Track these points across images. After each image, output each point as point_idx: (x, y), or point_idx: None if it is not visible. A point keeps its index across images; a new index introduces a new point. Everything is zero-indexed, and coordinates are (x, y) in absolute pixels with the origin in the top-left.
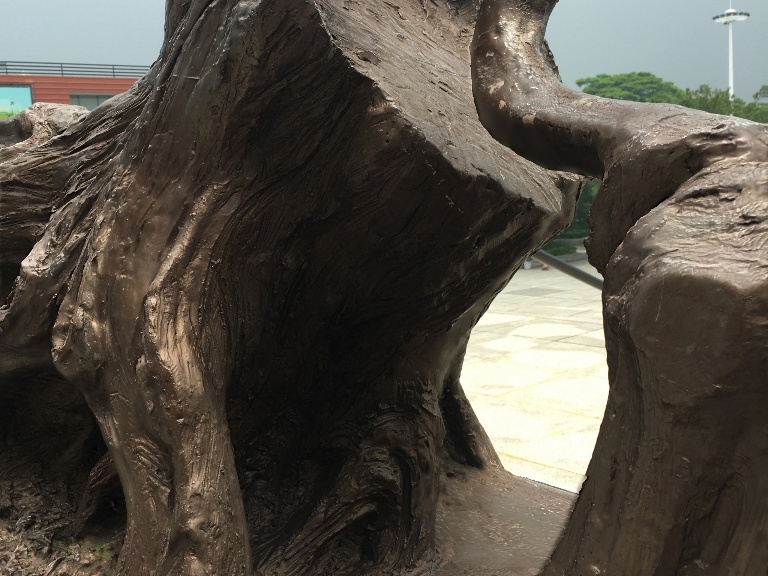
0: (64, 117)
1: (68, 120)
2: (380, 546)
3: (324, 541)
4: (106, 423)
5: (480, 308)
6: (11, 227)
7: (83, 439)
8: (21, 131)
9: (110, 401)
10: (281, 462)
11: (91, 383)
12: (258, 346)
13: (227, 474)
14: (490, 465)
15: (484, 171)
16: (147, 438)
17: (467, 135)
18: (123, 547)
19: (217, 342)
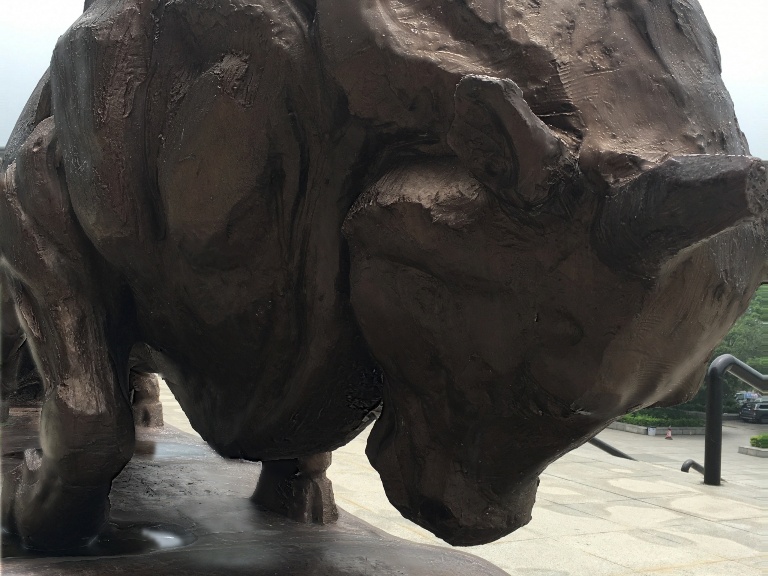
0: None
1: None
2: (38, 395)
3: (20, 389)
4: None
5: None
6: None
7: None
8: None
9: None
10: (20, 368)
11: None
12: None
13: None
14: None
15: None
16: None
17: None
18: None
19: None
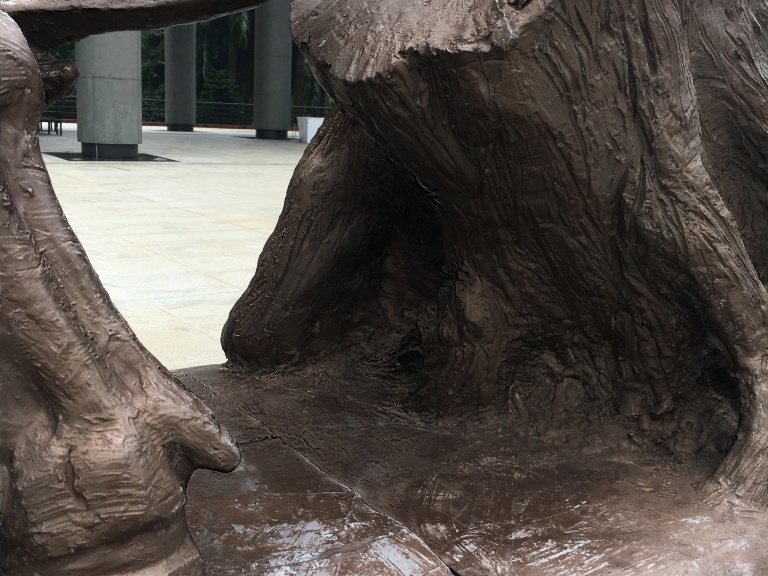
0: None
1: None
2: None
3: None
4: None
5: (486, 199)
6: None
7: None
8: None
9: None
10: None
11: None
12: (396, 183)
13: (288, 239)
14: (715, 478)
15: (310, 38)
16: None
17: (348, 6)
18: None
19: (339, 163)
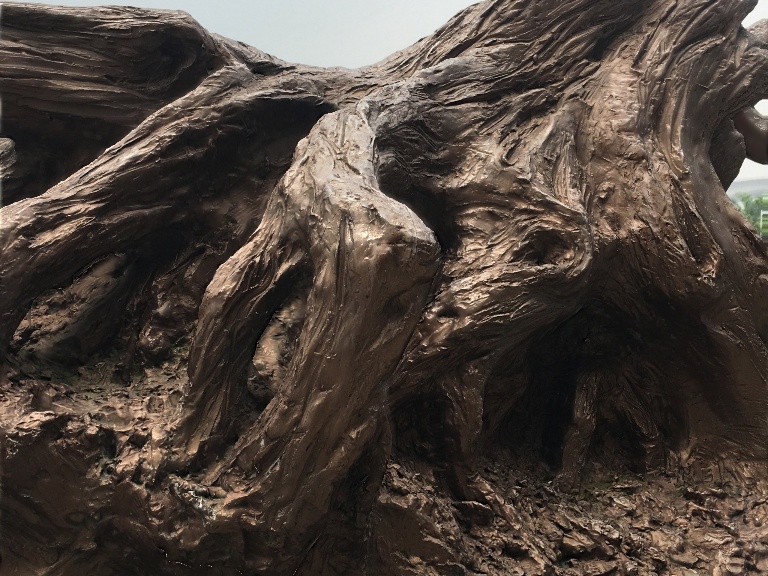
0: (235, 44)
1: (248, 50)
2: None
3: None
4: (727, 333)
5: None
6: (419, 174)
7: (511, 404)
8: (184, 43)
9: (733, 314)
10: None
11: (714, 304)
12: None
13: None
14: None
15: None
16: (758, 335)
17: None
18: None
19: None
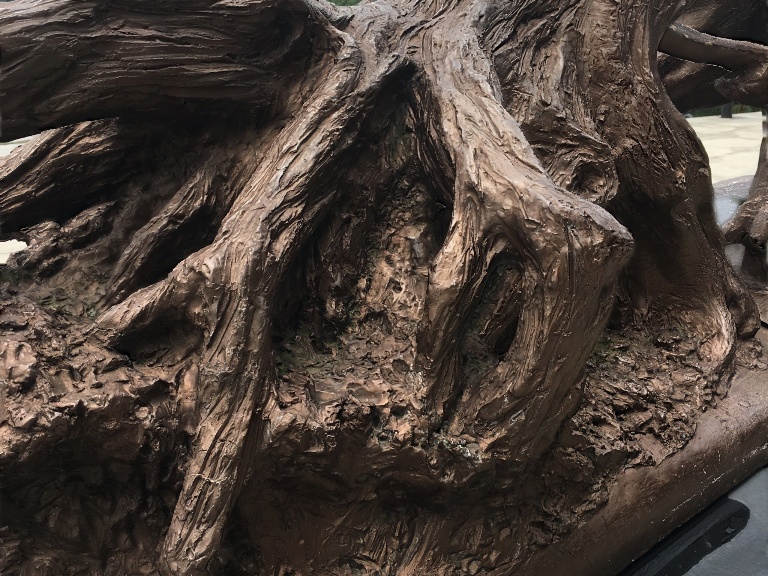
0: None
1: None
2: None
3: None
4: (683, 220)
5: None
6: None
7: None
8: (293, 15)
9: (686, 204)
10: None
11: None
12: None
13: None
14: None
15: None
16: None
17: None
18: (709, 273)
19: None
